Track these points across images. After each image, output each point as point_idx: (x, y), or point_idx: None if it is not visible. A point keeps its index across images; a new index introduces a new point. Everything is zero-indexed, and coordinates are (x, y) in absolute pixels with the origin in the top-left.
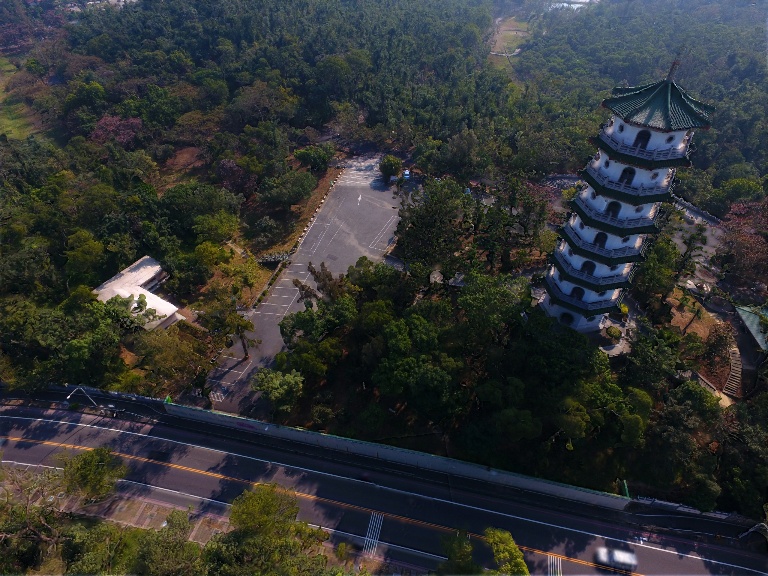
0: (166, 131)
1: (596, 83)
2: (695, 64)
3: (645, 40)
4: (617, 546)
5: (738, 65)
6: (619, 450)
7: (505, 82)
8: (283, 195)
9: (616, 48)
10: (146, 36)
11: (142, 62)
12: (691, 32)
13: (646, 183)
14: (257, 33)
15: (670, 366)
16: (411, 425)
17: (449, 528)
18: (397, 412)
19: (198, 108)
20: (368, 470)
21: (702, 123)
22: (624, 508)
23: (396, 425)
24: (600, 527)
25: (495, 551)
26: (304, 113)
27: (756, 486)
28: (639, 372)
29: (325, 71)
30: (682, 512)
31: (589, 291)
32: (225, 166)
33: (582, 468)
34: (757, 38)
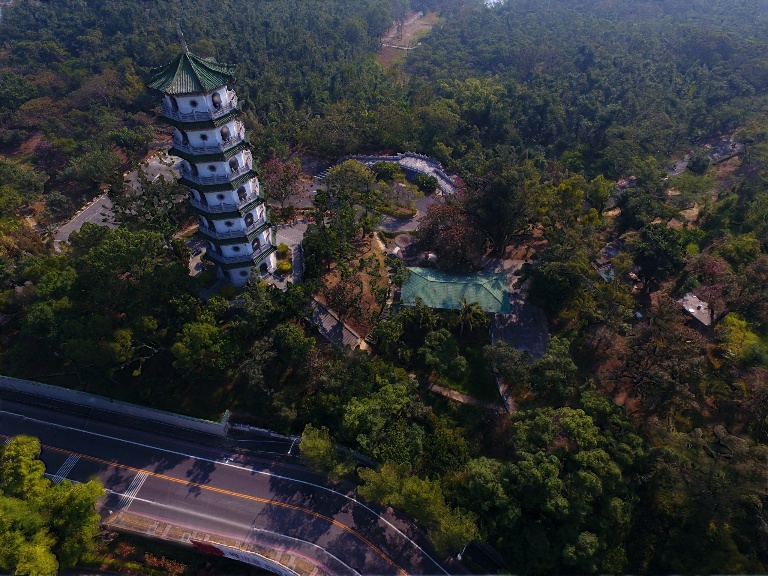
0: (18, 116)
1: (462, 74)
2: (540, 55)
3: (527, 34)
4: (203, 465)
5: (578, 56)
6: (239, 386)
7: (344, 71)
8: (77, 173)
9: (496, 41)
10: (32, 27)
11: (16, 52)
12: (570, 26)
13: (196, 143)
14: (138, 25)
15: (255, 308)
16: (66, 366)
17: (66, 451)
18: (61, 355)
19: (56, 95)
20: (25, 405)
21: (200, 88)
22: (227, 435)
23: (54, 366)
24: (198, 450)
25: (5, 450)
26: (151, 100)
27: (324, 412)
28: (235, 314)
29: (166, 60)
30: (276, 438)
31: (221, 246)
32: (41, 147)
33: (173, 396)
34: (633, 32)
